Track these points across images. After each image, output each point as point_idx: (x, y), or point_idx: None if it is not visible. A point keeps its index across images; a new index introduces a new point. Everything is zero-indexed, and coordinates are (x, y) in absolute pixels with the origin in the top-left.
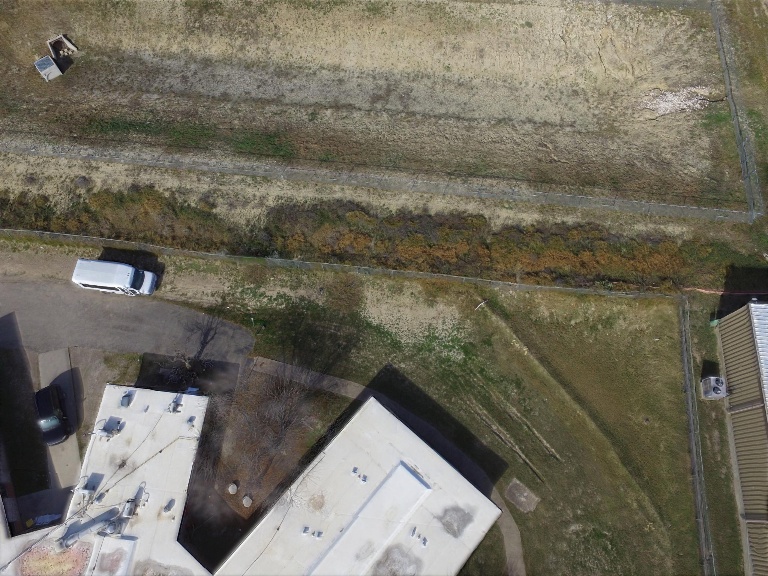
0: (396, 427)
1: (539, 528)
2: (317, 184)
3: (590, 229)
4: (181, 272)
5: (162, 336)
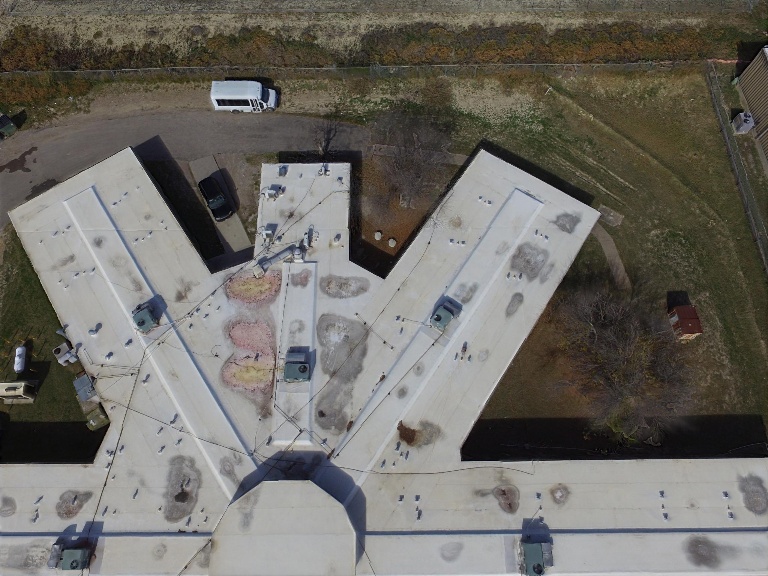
0: (506, 167)
1: (627, 235)
2: (399, 13)
3: (627, 24)
4: (296, 92)
5: (291, 138)
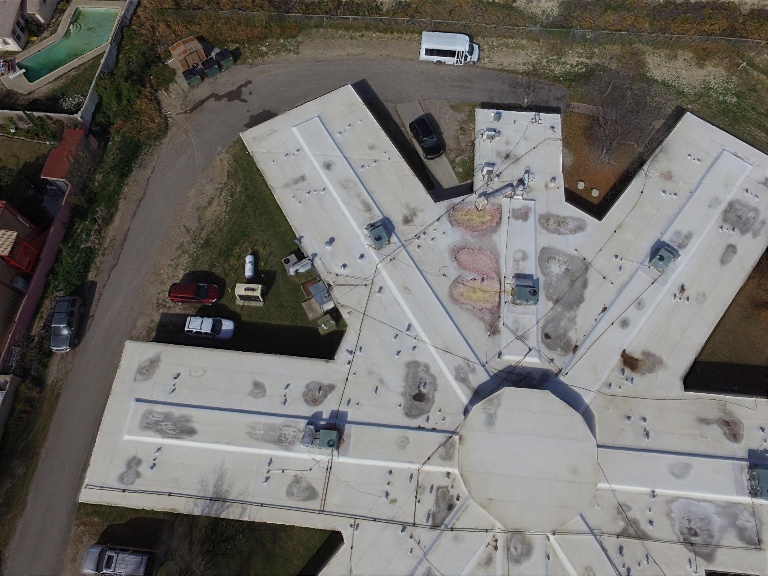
0: (713, 129)
1: None
2: None
3: None
4: (494, 49)
5: (492, 91)
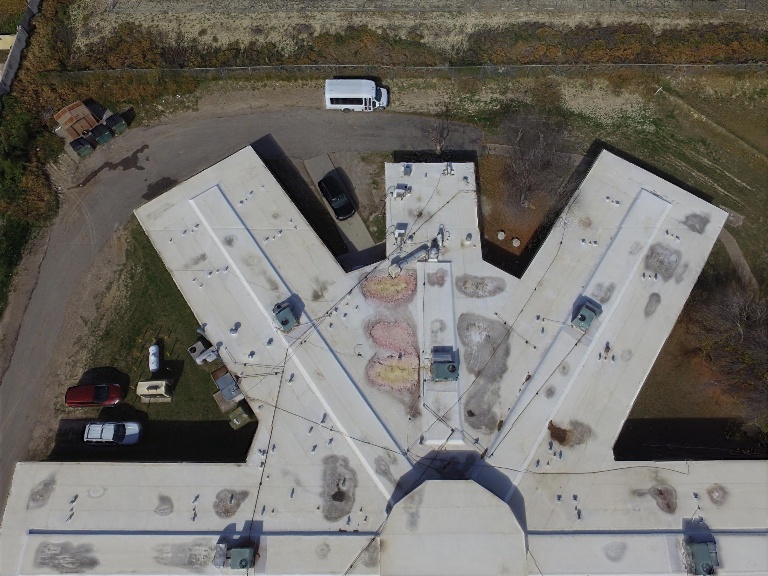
0: (630, 167)
1: (749, 236)
2: (504, 13)
3: (734, 25)
4: (405, 91)
5: (405, 138)
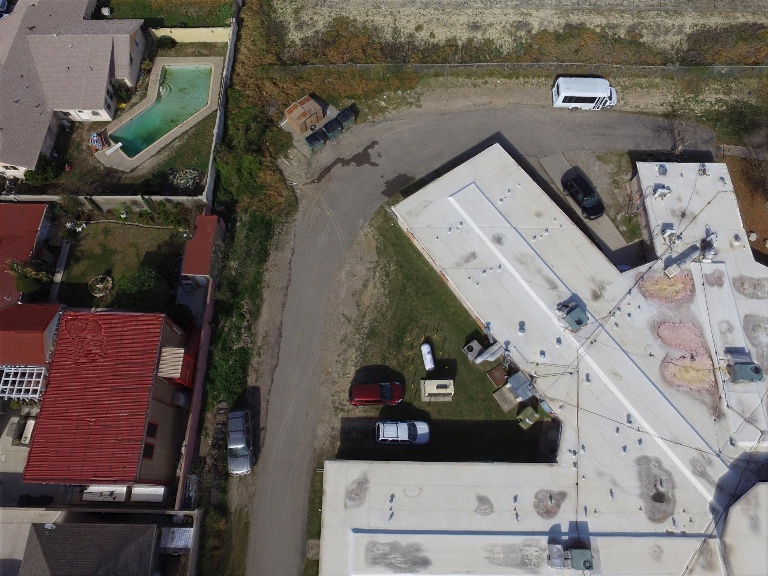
0: None
1: None
2: (721, 13)
3: None
4: (627, 90)
5: (636, 137)
